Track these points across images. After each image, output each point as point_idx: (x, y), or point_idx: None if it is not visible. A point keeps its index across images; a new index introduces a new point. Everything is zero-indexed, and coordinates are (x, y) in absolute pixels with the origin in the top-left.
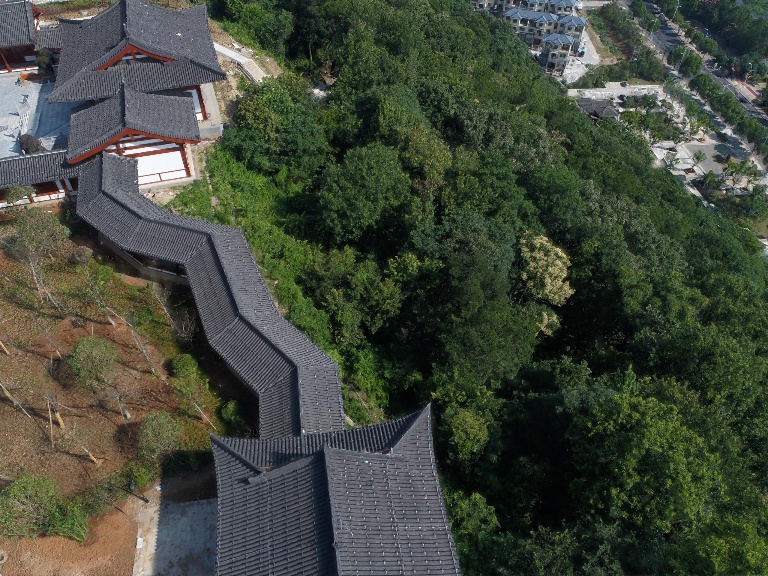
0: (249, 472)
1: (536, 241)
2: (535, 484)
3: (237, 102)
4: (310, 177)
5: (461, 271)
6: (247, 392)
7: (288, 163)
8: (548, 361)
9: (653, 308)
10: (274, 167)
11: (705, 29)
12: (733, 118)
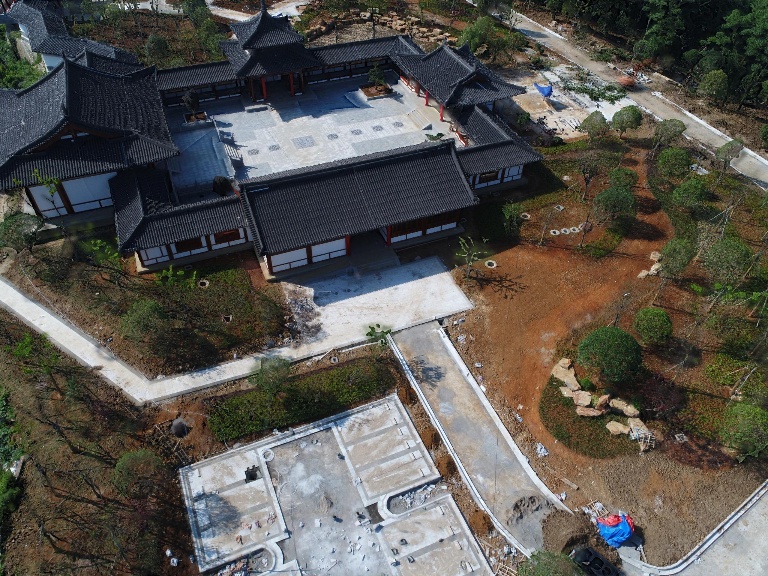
0: None
1: None
2: None
3: None
4: None
5: None
6: None
7: None
8: None
9: None
10: None
11: None
12: None
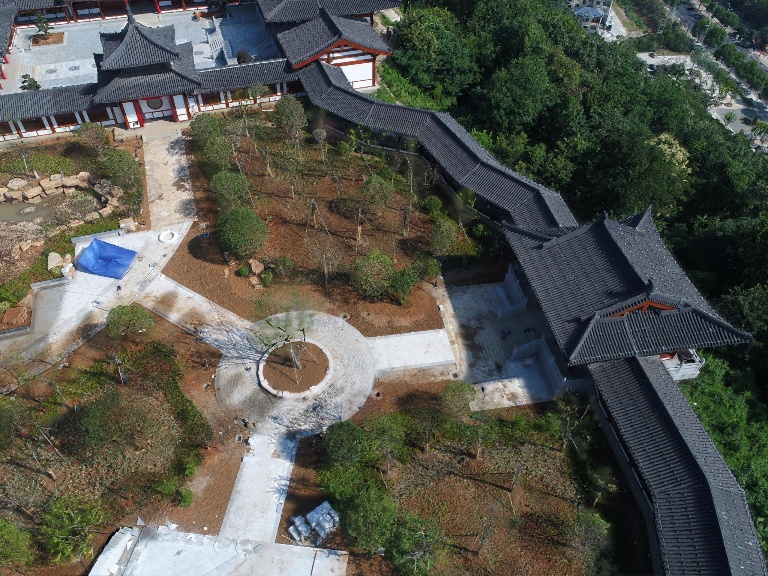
0: (538, 242)
1: (661, 136)
2: (707, 284)
3: (389, 33)
4: (455, 95)
5: (628, 142)
6: None
7: (442, 81)
8: (682, 224)
9: (762, 184)
10: (431, 84)
11: (727, 3)
12: (758, 84)
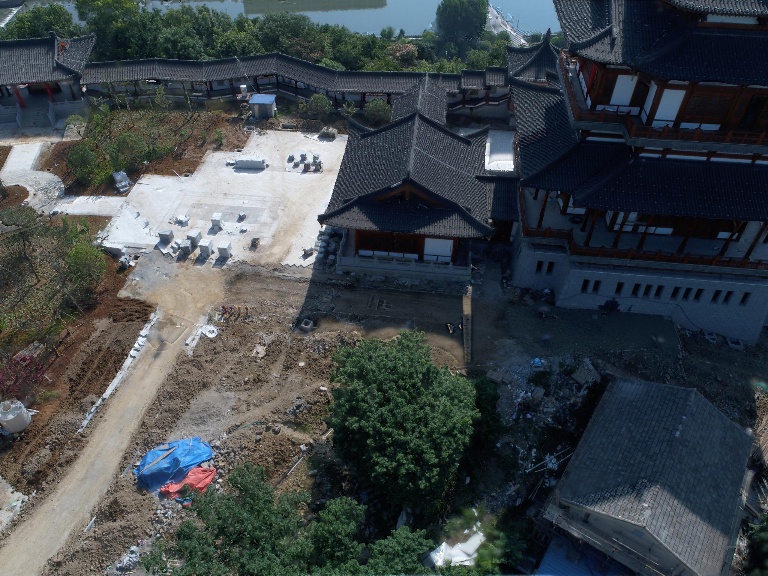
0: None
1: None
2: None
3: None
4: None
5: None
6: None
7: None
8: None
9: None
10: None
11: None
12: None
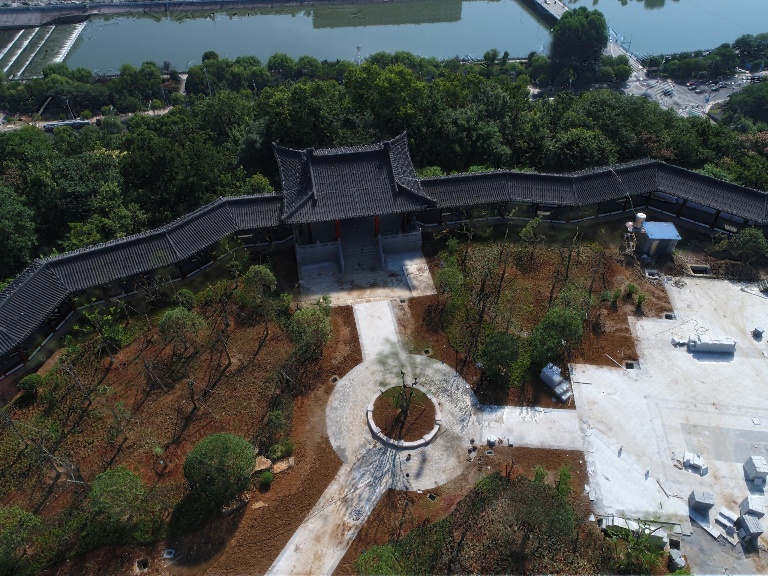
0: (309, 204)
1: None
2: None
3: None
4: None
5: None
6: (214, 270)
7: None
8: None
9: None
10: None
11: None
12: None
